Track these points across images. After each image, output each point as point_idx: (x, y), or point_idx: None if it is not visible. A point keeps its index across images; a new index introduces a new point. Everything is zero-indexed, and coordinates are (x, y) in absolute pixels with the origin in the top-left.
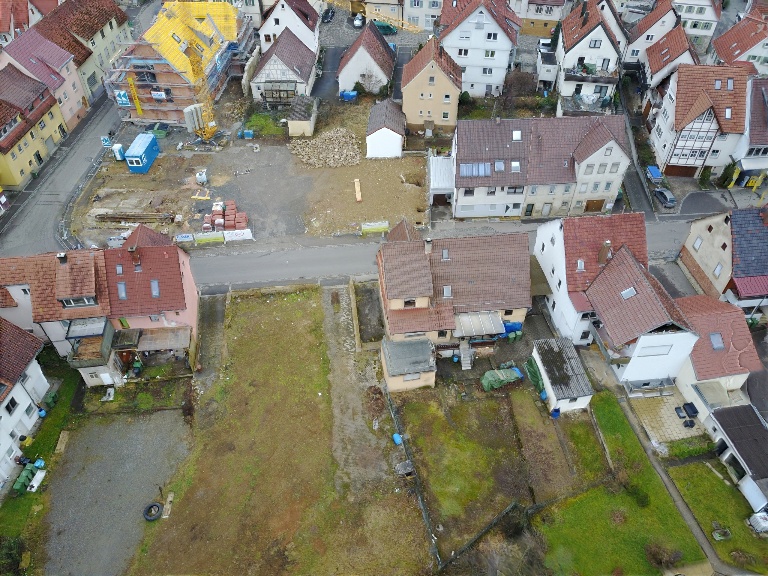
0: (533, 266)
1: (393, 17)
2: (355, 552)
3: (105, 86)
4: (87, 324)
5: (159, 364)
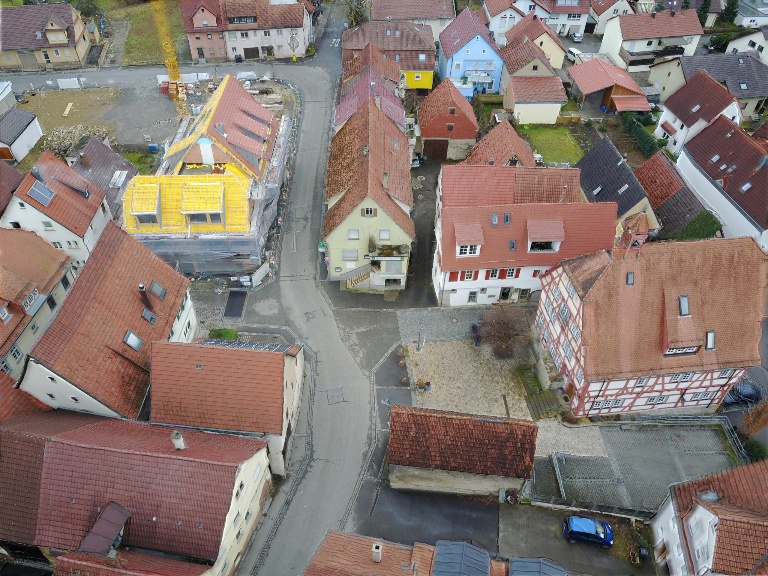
0: None
1: None
2: (131, 11)
3: None
4: None
5: None
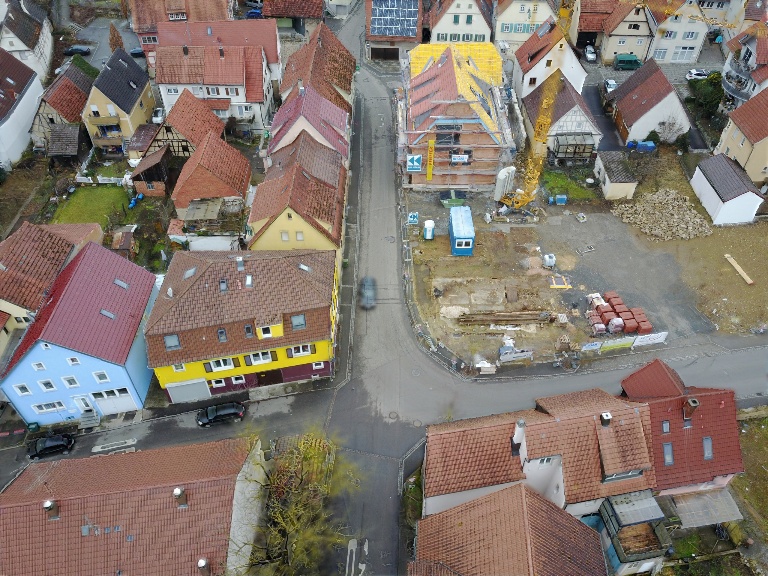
0: None
1: (638, 50)
2: None
3: (398, 150)
4: (633, 501)
5: (681, 535)
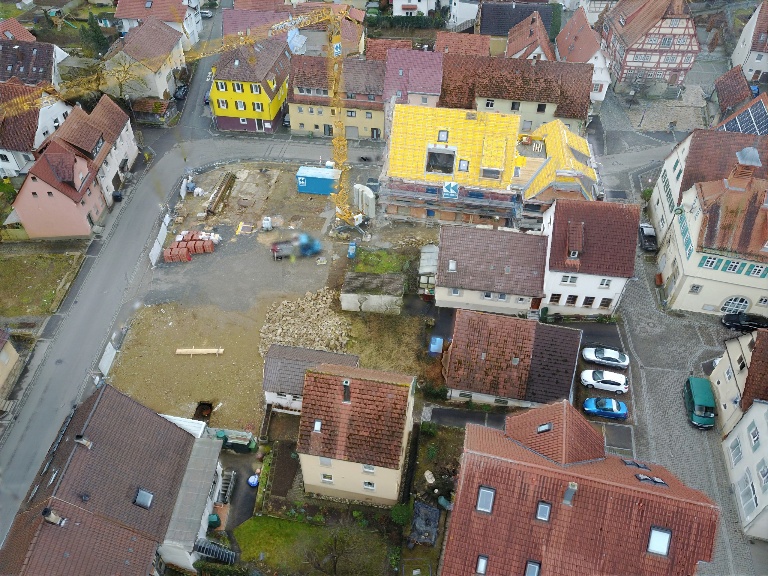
0: None
1: None
2: None
3: None
4: None
5: None
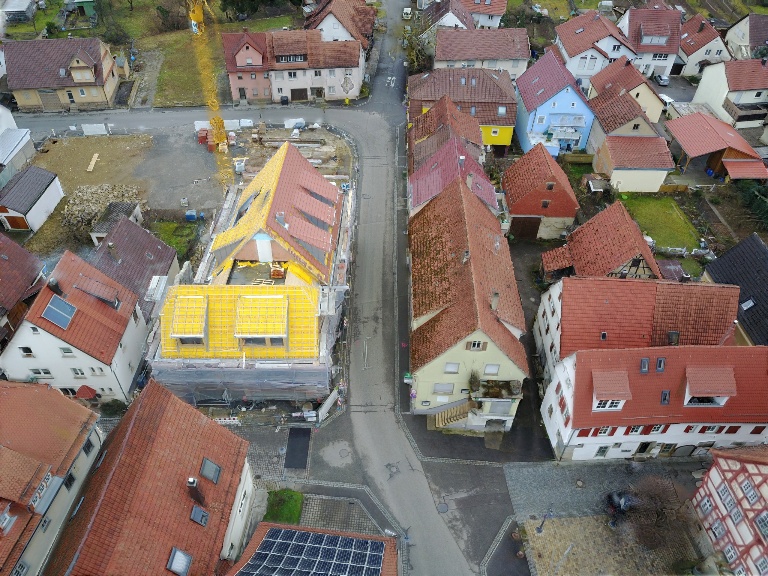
0: (0, 87)
1: None
2: None
3: None
4: None
5: None
